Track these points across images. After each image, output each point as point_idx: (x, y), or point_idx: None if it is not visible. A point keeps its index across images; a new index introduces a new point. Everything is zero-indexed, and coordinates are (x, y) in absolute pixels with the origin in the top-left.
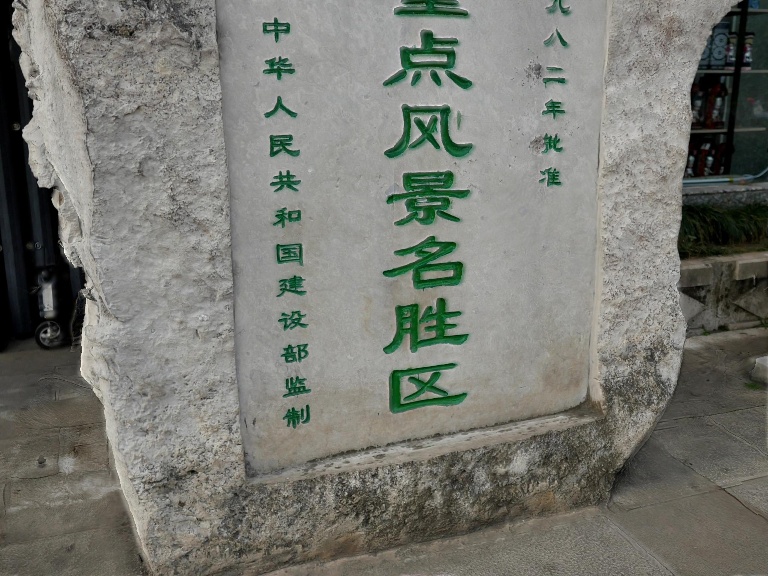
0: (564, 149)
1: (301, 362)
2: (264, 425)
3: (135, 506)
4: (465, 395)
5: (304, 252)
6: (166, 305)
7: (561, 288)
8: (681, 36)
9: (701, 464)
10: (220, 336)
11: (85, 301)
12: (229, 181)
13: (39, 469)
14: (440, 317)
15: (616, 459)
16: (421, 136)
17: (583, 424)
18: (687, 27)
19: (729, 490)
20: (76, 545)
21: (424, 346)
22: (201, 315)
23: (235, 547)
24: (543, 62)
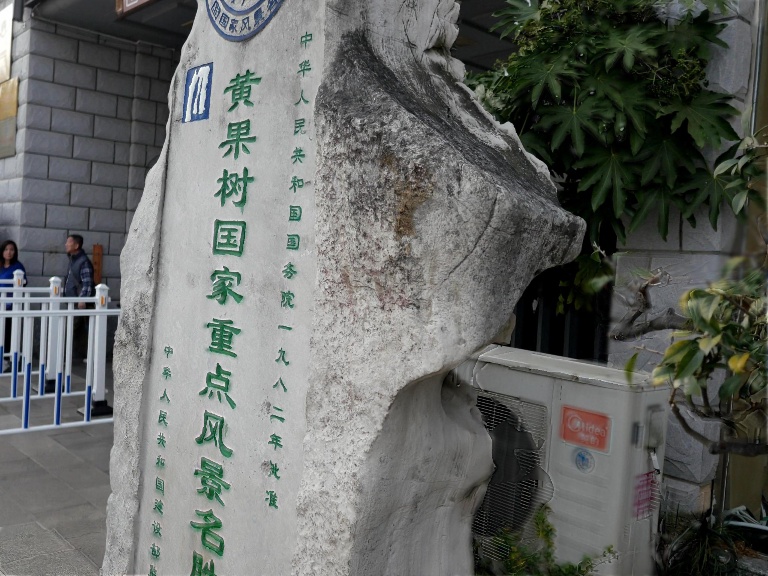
0: (280, 479)
1: None
2: None
3: None
4: None
5: None
6: None
7: None
8: (360, 405)
9: None
10: None
11: None
12: (142, 430)
13: None
14: (213, 575)
15: None
16: (211, 434)
17: None
18: (365, 397)
19: None
20: None
21: None
22: None
23: None
24: (272, 402)
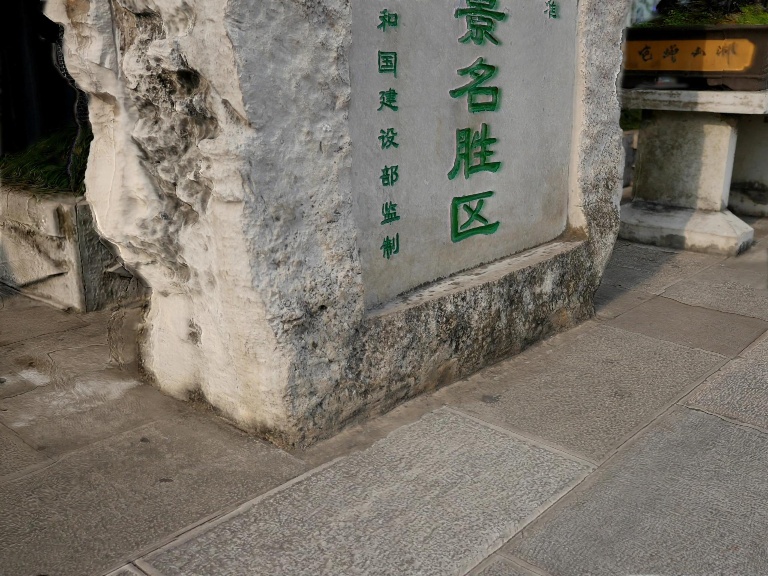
0: None
1: (393, 185)
2: (367, 256)
3: (264, 356)
4: (498, 223)
5: (397, 62)
6: (294, 111)
7: (554, 120)
8: None
9: (626, 284)
10: (340, 150)
11: (88, 150)
12: None
13: (7, 387)
14: (482, 143)
15: (595, 277)
16: None
17: (579, 245)
18: None
19: (663, 295)
20: (148, 438)
21: (473, 173)
22: (324, 125)
23: (360, 388)
24: None
